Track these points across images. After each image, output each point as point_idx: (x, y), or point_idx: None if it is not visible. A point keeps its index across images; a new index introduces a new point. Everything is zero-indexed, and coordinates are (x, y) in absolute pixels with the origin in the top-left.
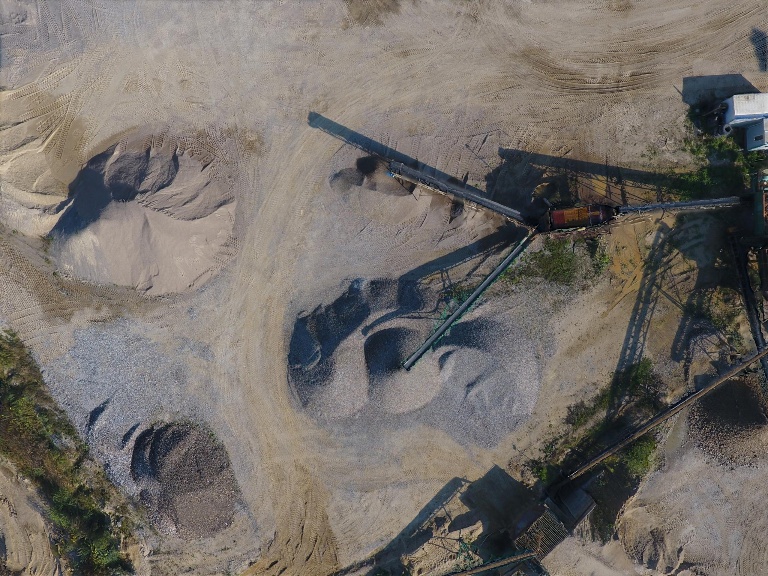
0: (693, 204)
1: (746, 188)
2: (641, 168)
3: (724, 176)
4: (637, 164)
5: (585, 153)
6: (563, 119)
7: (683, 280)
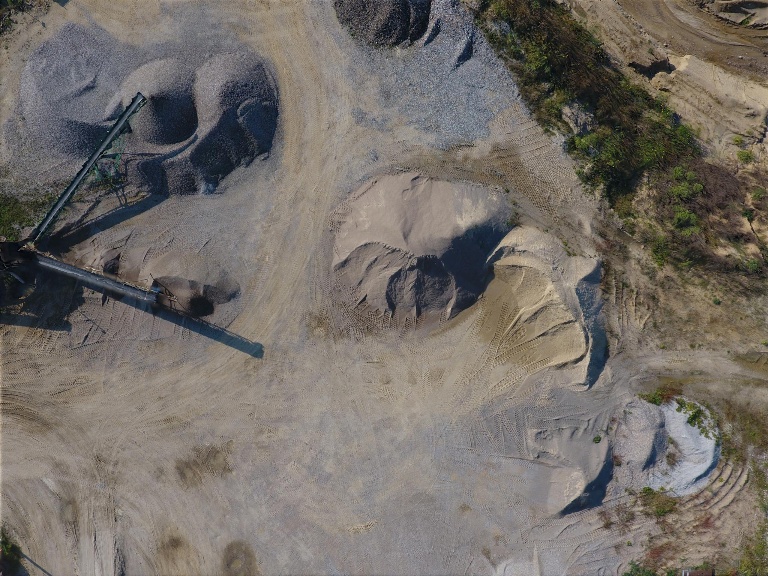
0: None
1: None
2: None
3: None
4: None
5: None
6: (5, 363)
7: None
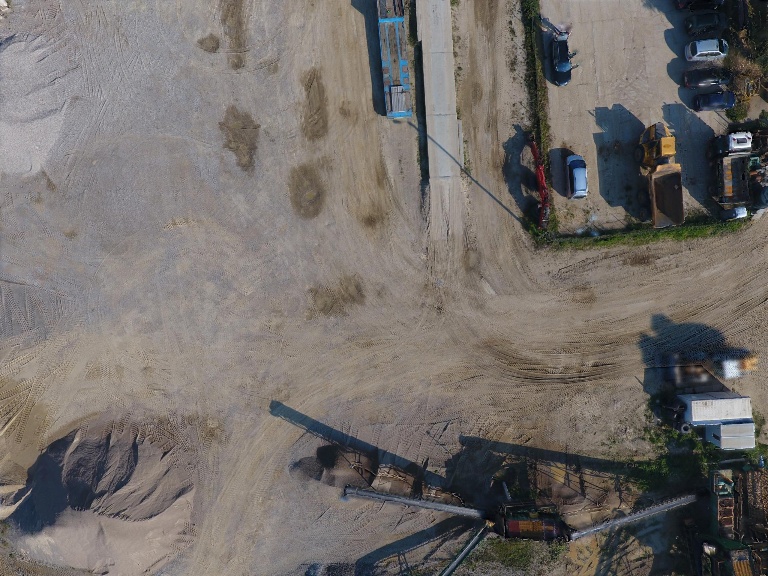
0: (647, 513)
1: (703, 477)
2: (600, 456)
3: (682, 466)
4: (596, 452)
5: (545, 441)
6: (524, 408)
7: (638, 566)
